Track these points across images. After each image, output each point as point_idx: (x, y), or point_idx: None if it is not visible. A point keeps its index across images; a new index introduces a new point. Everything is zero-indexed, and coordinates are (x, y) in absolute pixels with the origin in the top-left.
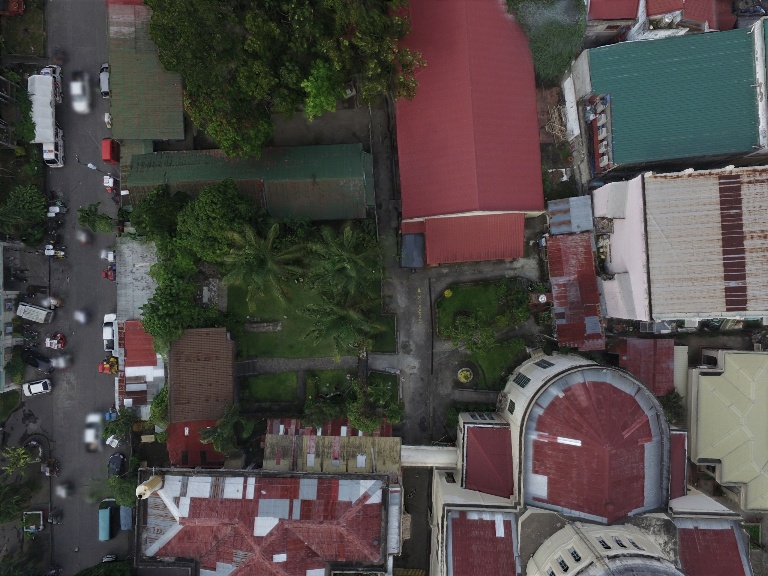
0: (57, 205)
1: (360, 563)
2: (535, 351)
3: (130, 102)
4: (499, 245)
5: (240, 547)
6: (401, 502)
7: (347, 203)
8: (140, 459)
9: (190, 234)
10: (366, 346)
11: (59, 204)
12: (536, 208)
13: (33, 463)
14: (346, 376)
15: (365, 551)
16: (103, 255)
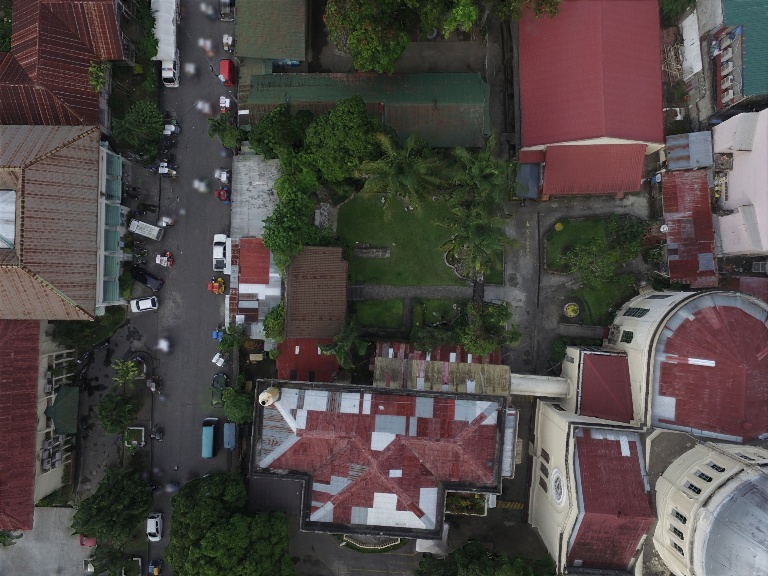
0: (172, 124)
1: (473, 484)
2: (644, 288)
3: (254, 21)
4: (617, 177)
5: (357, 461)
6: (516, 425)
7: (465, 130)
8: (246, 378)
9: (320, 146)
10: (484, 270)
11: (174, 123)
12: (657, 141)
13: (137, 379)
14: (452, 306)
15: (479, 472)
16: (217, 174)
